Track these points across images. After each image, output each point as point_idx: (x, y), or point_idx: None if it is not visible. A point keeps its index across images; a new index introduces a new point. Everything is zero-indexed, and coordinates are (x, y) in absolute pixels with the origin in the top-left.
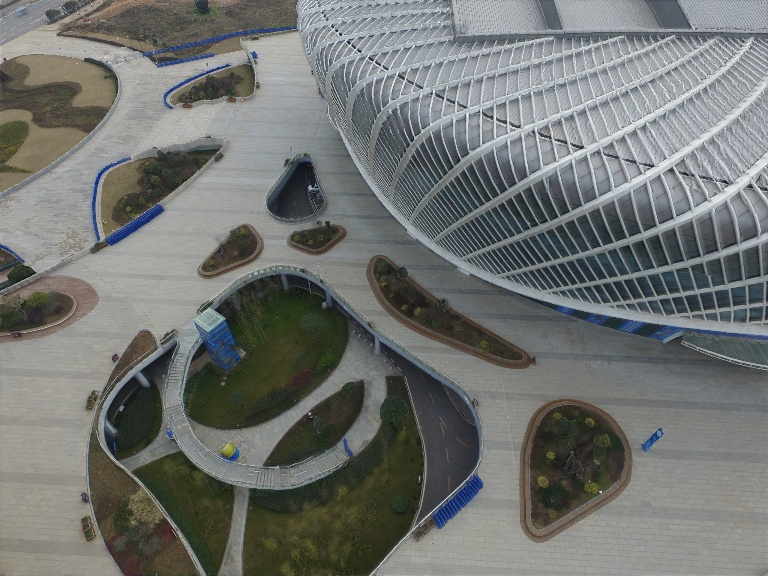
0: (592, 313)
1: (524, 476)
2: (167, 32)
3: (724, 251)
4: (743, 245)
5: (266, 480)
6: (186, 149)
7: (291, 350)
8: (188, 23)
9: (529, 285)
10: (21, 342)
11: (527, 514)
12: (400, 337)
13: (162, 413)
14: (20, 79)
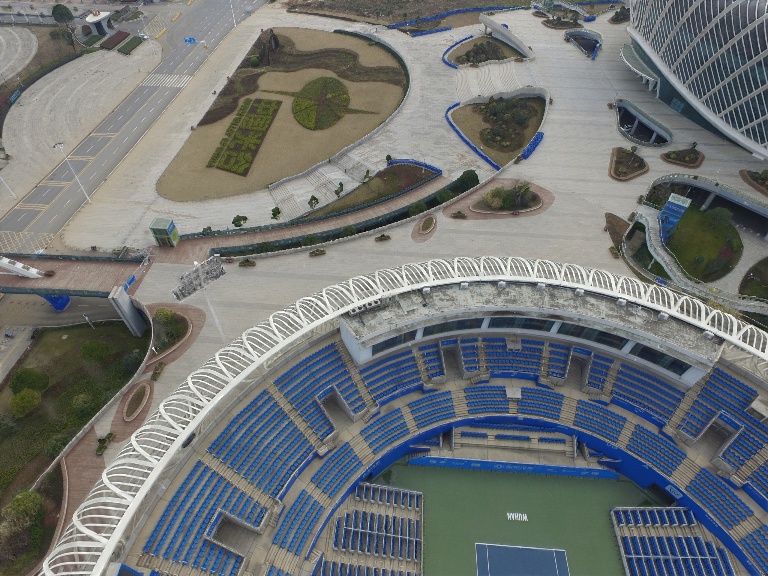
0: None
1: None
2: (388, 10)
3: None
4: None
5: (764, 308)
6: (508, 97)
7: (703, 235)
8: (403, 3)
9: None
10: (522, 218)
11: None
12: None
13: None
14: (290, 46)
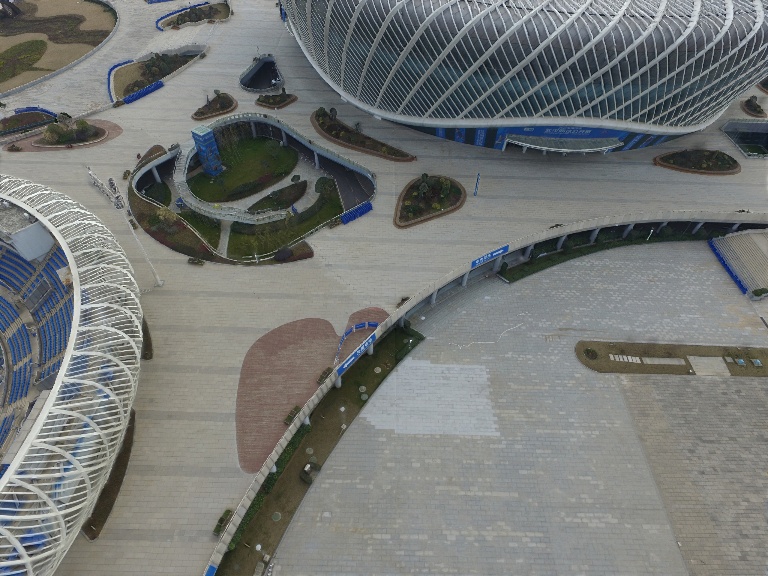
0: (454, 129)
1: (398, 204)
2: None
3: (493, 46)
4: (500, 39)
5: (241, 217)
6: None
7: (258, 165)
8: None
9: (415, 114)
10: (73, 150)
11: (397, 218)
12: (330, 148)
13: (171, 195)
14: (31, 13)
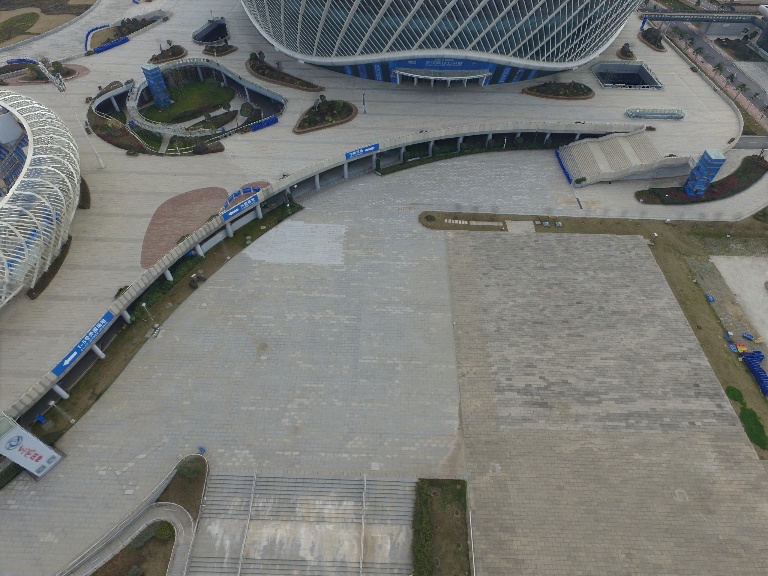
0: (357, 66)
1: None
2: None
3: None
4: None
5: (177, 131)
6: (146, 19)
7: (199, 99)
8: None
9: (326, 55)
10: (49, 84)
11: (296, 127)
12: None
13: (126, 120)
14: None
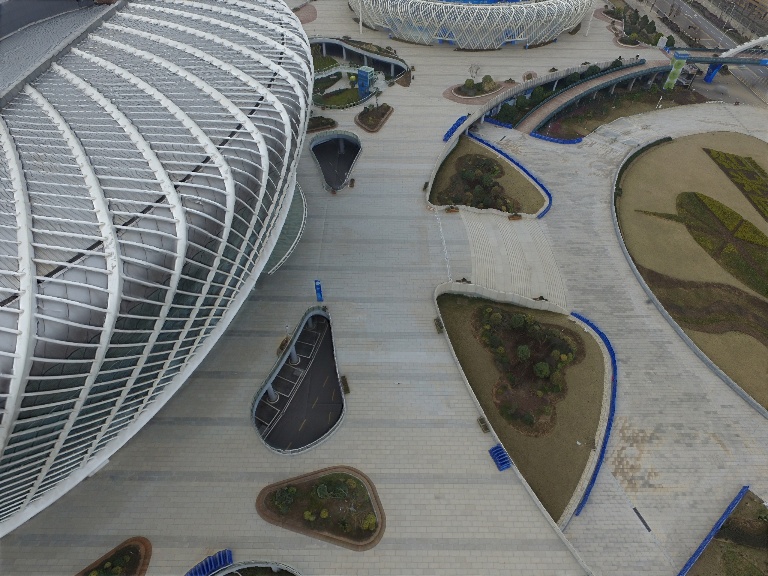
0: None
1: None
2: None
3: None
4: None
5: None
6: None
7: None
8: None
9: None
10: None
11: None
12: None
13: None
14: None
